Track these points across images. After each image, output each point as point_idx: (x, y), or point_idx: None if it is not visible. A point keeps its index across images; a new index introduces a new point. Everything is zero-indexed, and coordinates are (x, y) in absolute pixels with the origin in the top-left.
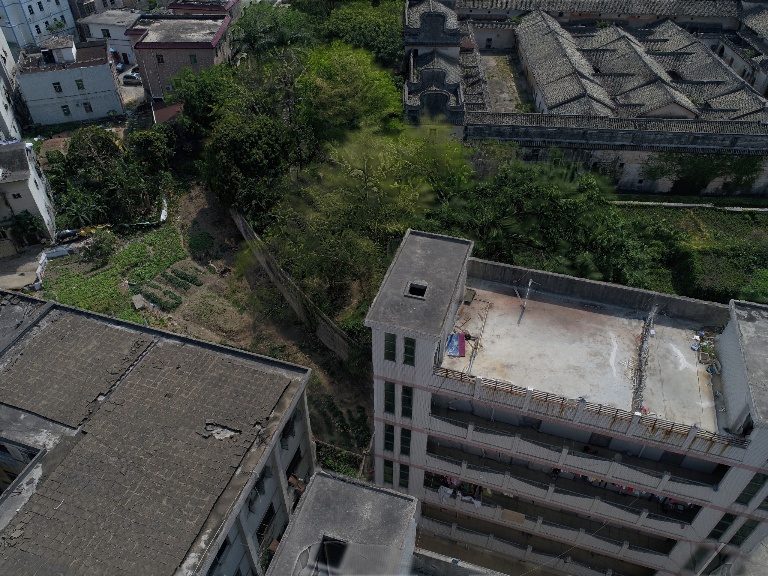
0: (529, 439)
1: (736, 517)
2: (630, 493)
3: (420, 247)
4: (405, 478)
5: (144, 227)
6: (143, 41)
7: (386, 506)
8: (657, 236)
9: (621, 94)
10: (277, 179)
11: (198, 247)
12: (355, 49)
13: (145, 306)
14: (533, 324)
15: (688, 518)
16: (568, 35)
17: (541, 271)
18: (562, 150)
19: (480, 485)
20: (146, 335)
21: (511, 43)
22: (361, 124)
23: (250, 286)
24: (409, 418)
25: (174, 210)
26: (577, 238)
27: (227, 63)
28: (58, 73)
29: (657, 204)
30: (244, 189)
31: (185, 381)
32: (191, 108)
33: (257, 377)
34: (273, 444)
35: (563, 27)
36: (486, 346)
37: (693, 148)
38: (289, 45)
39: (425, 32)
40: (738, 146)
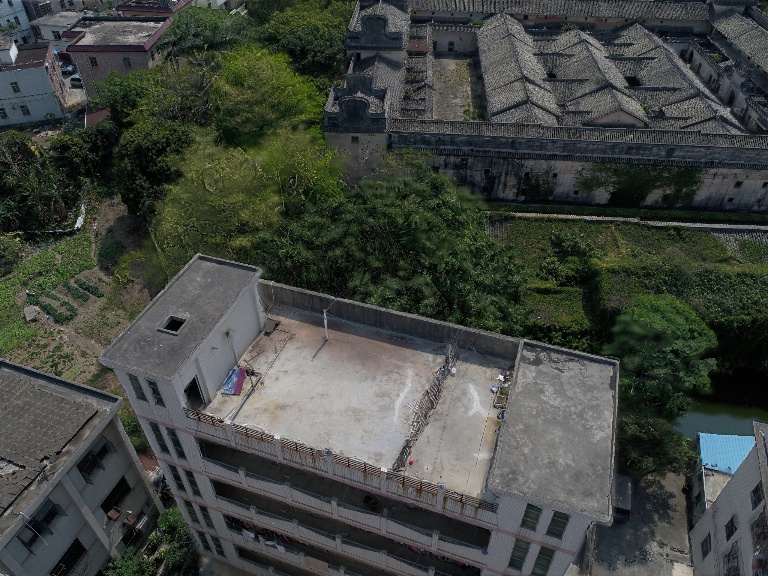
0: (299, 488)
1: None
2: (412, 549)
3: (202, 274)
4: (209, 519)
5: (56, 235)
6: (77, 44)
7: None
8: (574, 252)
9: (571, 100)
10: (186, 187)
11: (107, 256)
12: (292, 53)
13: (37, 318)
14: (329, 359)
15: None
16: (529, 39)
17: (347, 300)
18: (491, 159)
19: (275, 531)
20: None
21: (474, 46)
22: (270, 132)
23: (151, 298)
24: (185, 460)
25: (92, 217)
26: (420, 261)
27: (161, 66)
28: None
29: (578, 218)
30: (149, 198)
31: None
32: (116, 113)
33: (62, 406)
34: (55, 482)
35: (527, 30)
36: (267, 383)
37: (628, 159)
38: (219, 49)
39: (366, 35)
40: (675, 157)
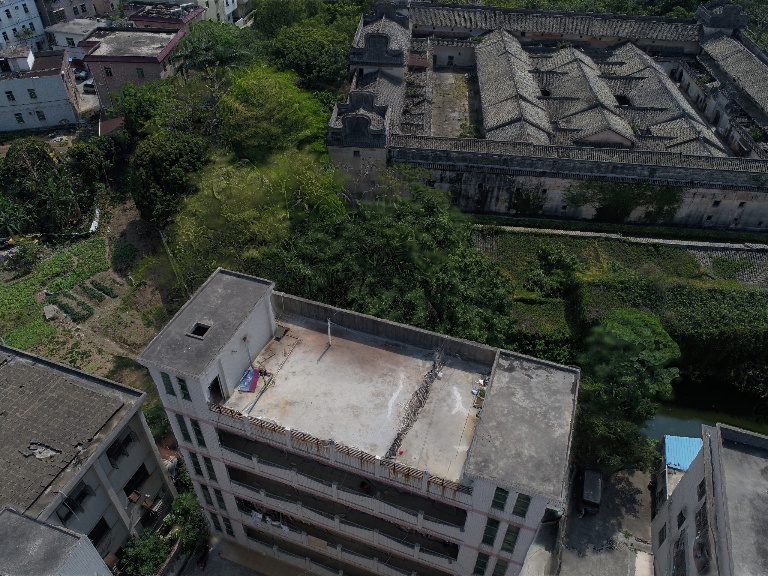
0: (304, 473)
1: (489, 556)
2: (401, 528)
3: (223, 286)
4: (222, 501)
5: (72, 237)
6: (93, 54)
7: (54, 543)
8: (559, 265)
9: (563, 118)
10: (196, 196)
11: (121, 259)
12: (298, 67)
13: (56, 316)
14: (332, 362)
15: (456, 554)
16: (525, 56)
17: (349, 311)
18: (485, 175)
19: (281, 512)
20: (2, 353)
21: (473, 61)
22: (277, 146)
23: (162, 300)
24: (205, 447)
25: (106, 221)
26: (414, 276)
27: (173, 77)
28: (10, 82)
29: (563, 233)
30: (162, 205)
31: (24, 400)
32: (130, 122)
33: (92, 399)
34: (88, 465)
35: (523, 47)
36: (278, 382)
37: (613, 177)
38: (229, 63)
39: (369, 52)
40: (657, 177)
